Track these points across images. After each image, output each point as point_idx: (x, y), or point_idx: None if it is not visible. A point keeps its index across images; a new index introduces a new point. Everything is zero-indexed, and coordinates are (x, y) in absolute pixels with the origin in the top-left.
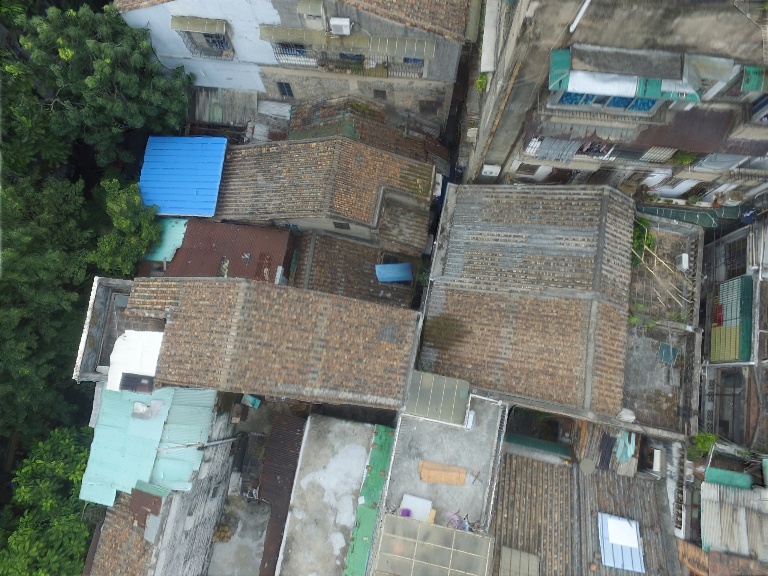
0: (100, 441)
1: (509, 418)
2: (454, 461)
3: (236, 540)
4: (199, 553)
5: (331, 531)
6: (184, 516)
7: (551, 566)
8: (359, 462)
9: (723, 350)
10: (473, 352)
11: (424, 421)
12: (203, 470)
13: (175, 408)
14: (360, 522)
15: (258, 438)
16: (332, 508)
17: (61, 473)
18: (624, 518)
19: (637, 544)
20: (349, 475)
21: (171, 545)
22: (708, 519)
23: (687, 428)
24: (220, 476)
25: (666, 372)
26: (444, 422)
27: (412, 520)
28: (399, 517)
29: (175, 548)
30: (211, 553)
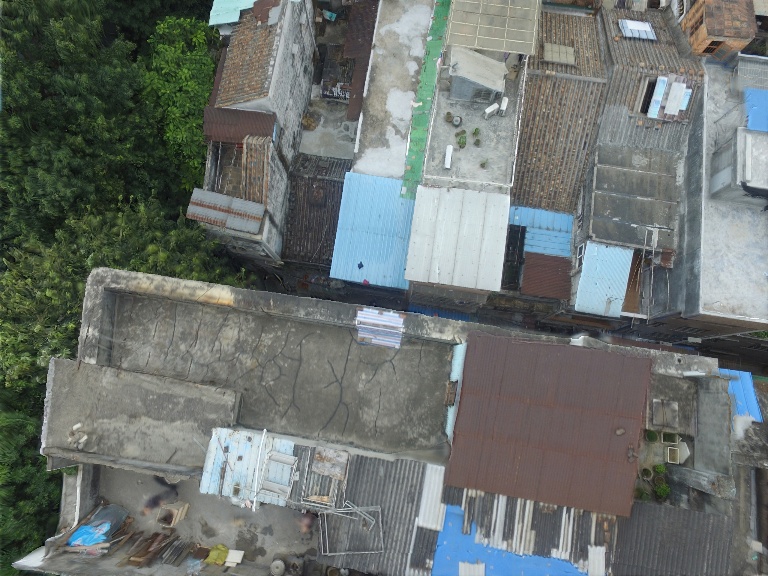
0: None
1: None
2: None
3: (320, 129)
4: (296, 111)
5: (406, 60)
6: (292, 38)
7: (583, 54)
8: (425, 16)
9: None
10: None
11: None
12: (303, 17)
13: None
14: (430, 50)
15: (335, 46)
16: (406, 46)
17: (188, 27)
18: (639, 21)
19: (649, 29)
20: (418, 24)
21: (286, 44)
22: None
23: None
24: (308, 65)
25: None
26: None
27: None
28: None
29: None
30: (301, 136)
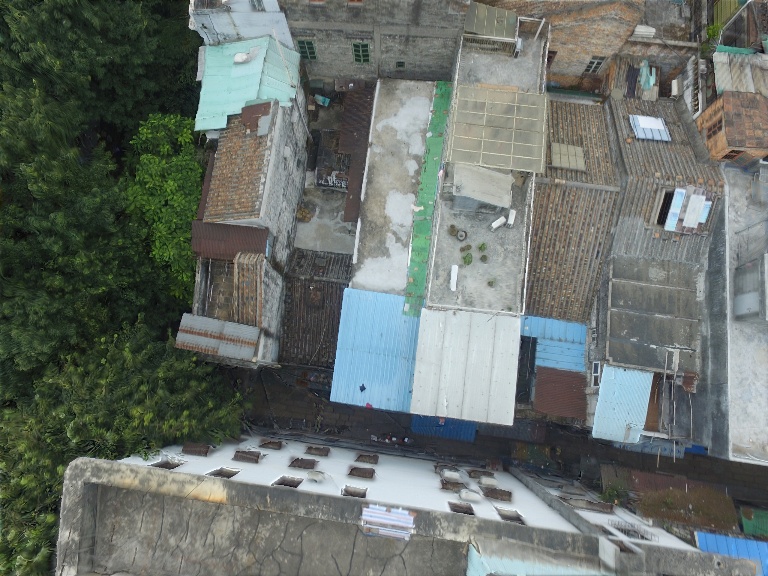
0: (208, 88)
1: (548, 66)
2: (507, 83)
3: (315, 221)
4: (290, 209)
5: (405, 159)
6: (284, 142)
7: (593, 154)
8: (424, 109)
9: (724, 12)
10: (516, 0)
11: (479, 56)
12: (294, 116)
13: (271, 52)
14: (430, 149)
15: (329, 132)
16: (405, 143)
17: (173, 128)
18: (651, 116)
19: (663, 127)
20: (417, 119)
21: (278, 152)
22: (721, 73)
23: (699, 39)
24: (301, 156)
25: (678, 11)
26: (498, 37)
27: (481, 88)
28: (470, 87)
29: (279, 162)
30: (295, 229)
